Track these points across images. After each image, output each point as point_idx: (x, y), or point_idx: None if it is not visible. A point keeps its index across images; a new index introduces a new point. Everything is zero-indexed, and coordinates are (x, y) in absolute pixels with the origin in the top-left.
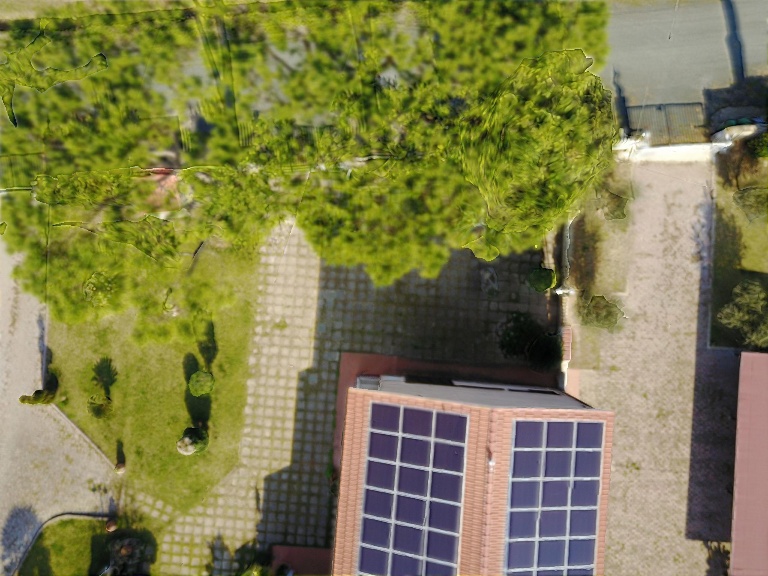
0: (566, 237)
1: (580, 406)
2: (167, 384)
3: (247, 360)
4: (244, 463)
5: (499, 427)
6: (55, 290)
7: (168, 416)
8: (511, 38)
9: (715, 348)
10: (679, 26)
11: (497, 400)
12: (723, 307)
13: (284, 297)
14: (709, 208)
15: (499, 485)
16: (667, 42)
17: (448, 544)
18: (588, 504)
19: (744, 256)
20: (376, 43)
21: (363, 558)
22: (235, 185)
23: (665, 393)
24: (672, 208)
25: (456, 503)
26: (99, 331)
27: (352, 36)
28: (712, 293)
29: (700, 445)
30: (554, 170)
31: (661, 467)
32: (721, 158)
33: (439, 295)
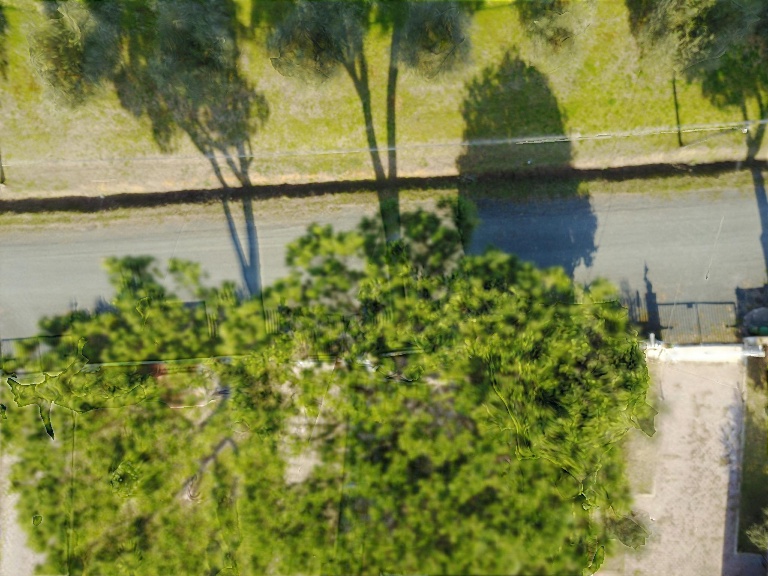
0: None
1: None
2: (191, 570)
3: (271, 549)
4: None
5: None
6: (81, 473)
7: None
8: (541, 231)
9: (742, 554)
10: (713, 223)
11: None
12: (752, 526)
13: (308, 487)
14: (740, 411)
15: None
16: (701, 239)
17: None
18: None
19: None
20: (404, 232)
21: None
22: (261, 374)
23: None
24: (702, 409)
25: None
26: (124, 515)
27: (380, 225)
28: (741, 498)
29: None
30: (587, 433)
31: None
32: (753, 360)
33: (464, 490)
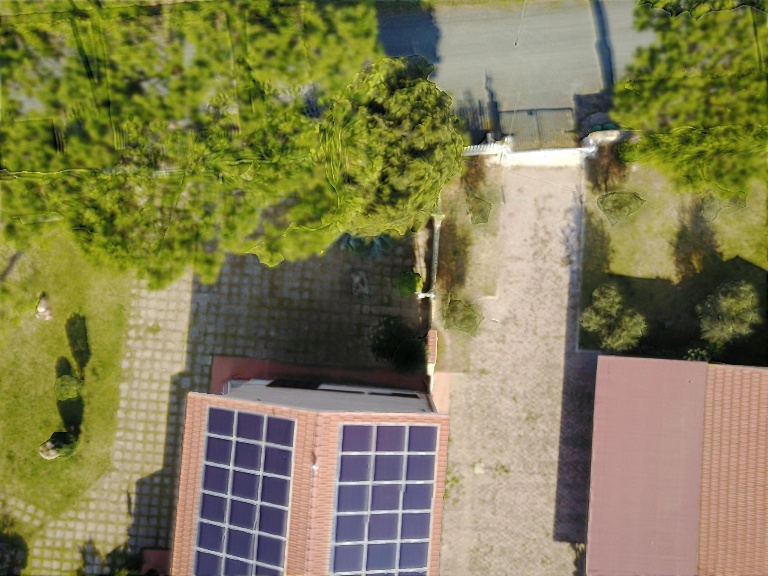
0: (435, 241)
1: (420, 410)
2: (39, 388)
3: (120, 364)
4: (116, 467)
5: (325, 431)
6: None
7: (40, 420)
8: (385, 43)
9: (583, 351)
10: (550, 32)
11: (340, 404)
12: (583, 311)
13: (157, 301)
14: (578, 212)
15: (325, 489)
16: (538, 48)
17: (276, 548)
18: (421, 507)
19: (612, 260)
20: (251, 47)
21: (199, 562)
22: (108, 188)
23: (534, 396)
24: (542, 212)
25: (283, 507)
26: None
27: (227, 40)
28: (580, 297)
29: (568, 447)
30: (388, 175)
31: (530, 469)
32: (590, 163)
33: (312, 299)
